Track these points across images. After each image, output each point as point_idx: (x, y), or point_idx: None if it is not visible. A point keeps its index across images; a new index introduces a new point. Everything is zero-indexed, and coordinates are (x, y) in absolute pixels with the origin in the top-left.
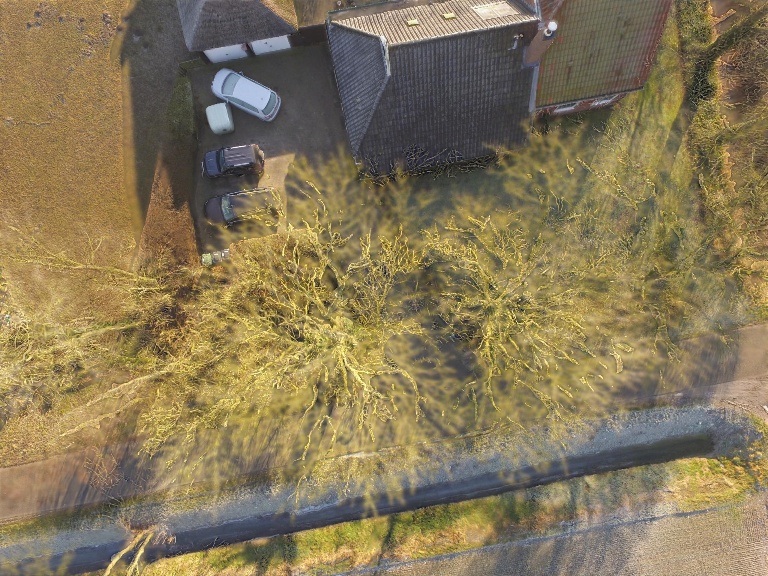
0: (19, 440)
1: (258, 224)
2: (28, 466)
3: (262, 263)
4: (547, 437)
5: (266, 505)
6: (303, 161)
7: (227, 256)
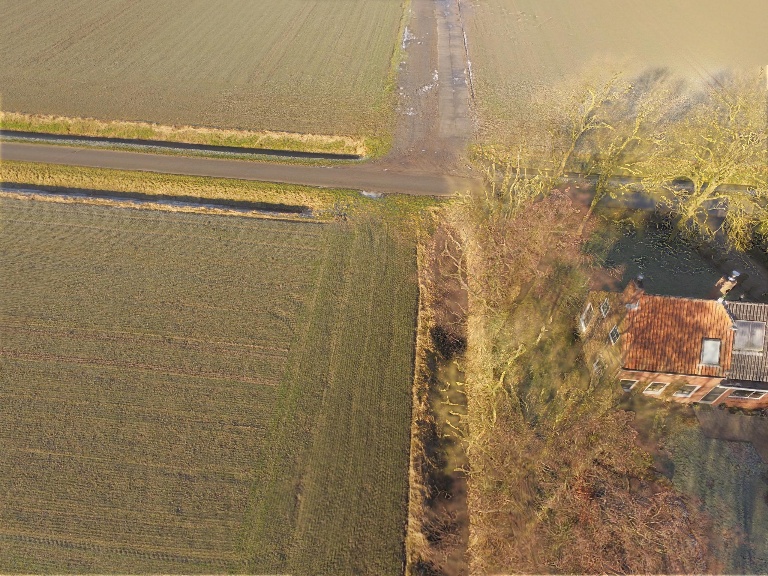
0: None
1: None
2: None
3: None
4: None
5: None
6: None
7: None
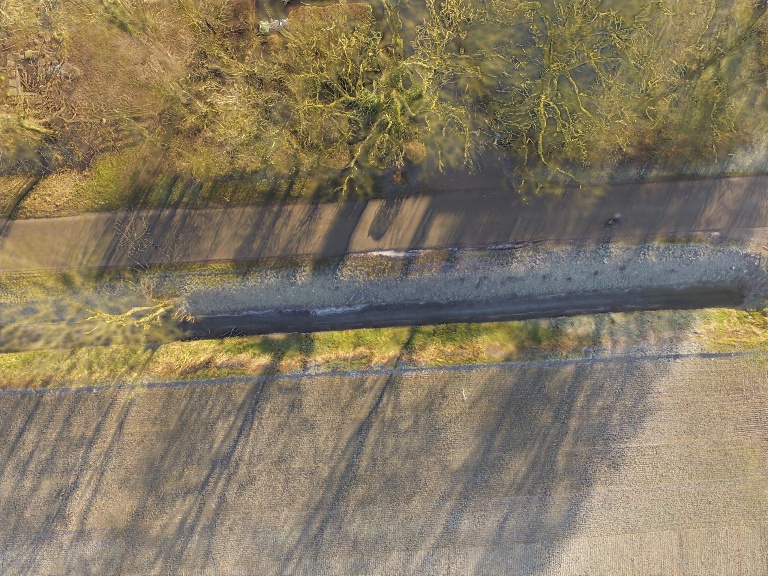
0: (53, 193)
1: (317, 5)
2: (59, 220)
3: None
4: (579, 259)
5: (289, 295)
6: None
7: (285, 25)
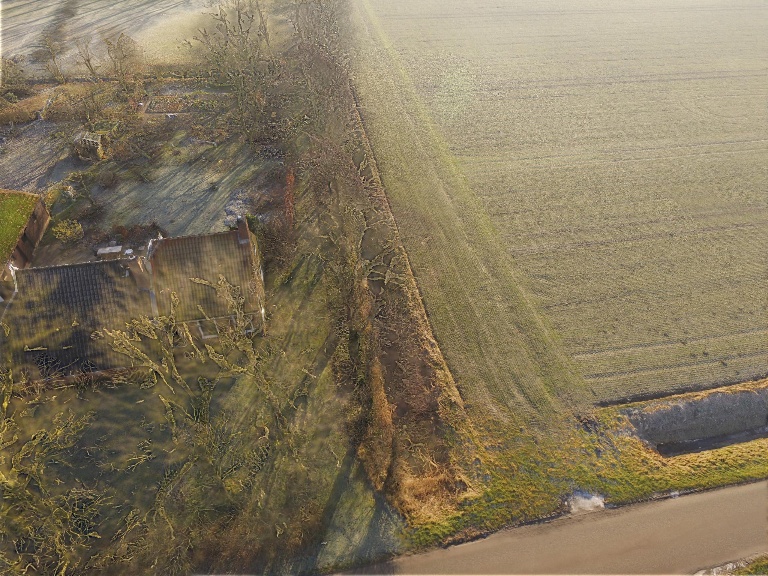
0: None
1: None
2: None
3: None
4: None
5: None
6: None
7: None
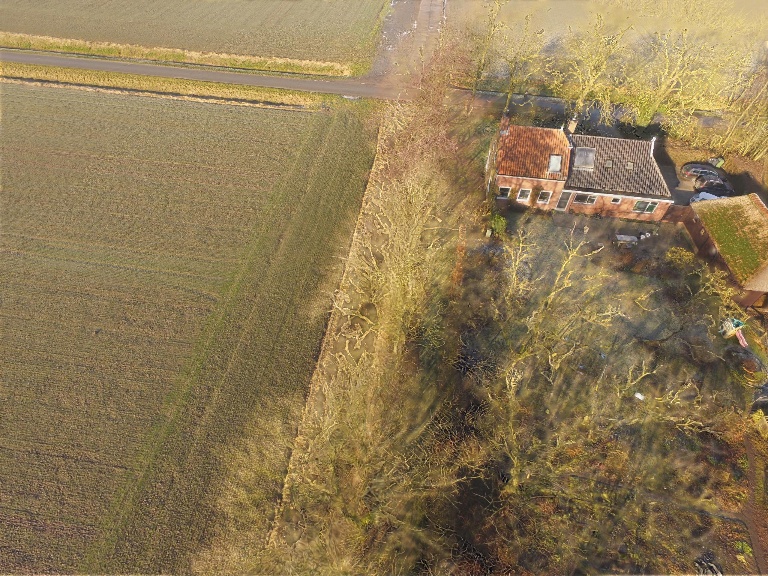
0: None
1: None
2: None
3: (691, 148)
4: None
5: None
6: (670, 186)
7: (710, 158)
